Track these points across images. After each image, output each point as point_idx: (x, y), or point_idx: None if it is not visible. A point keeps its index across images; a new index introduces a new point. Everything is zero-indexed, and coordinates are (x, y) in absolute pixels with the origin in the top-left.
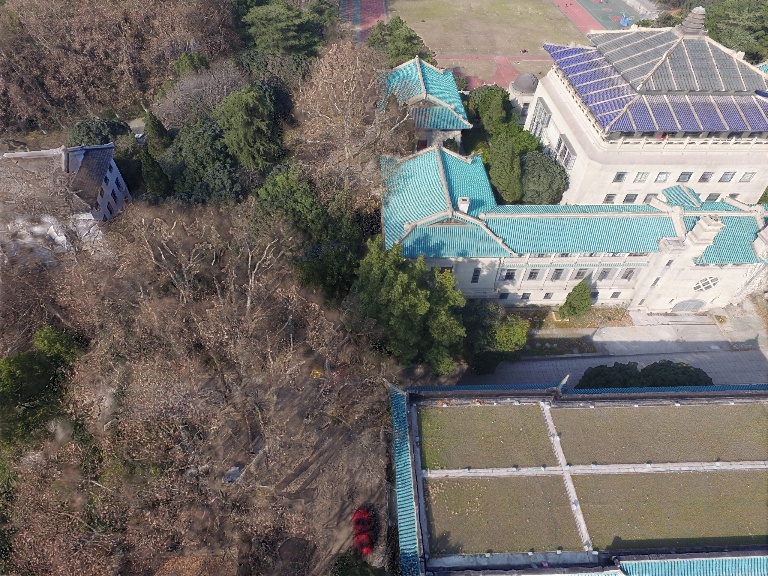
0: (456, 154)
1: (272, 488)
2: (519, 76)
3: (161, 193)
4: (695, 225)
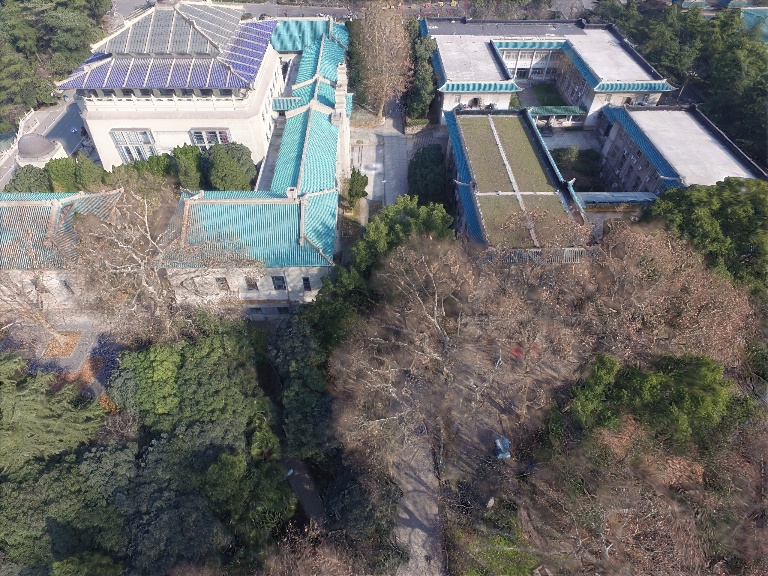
0: (197, 196)
1: (504, 416)
2: (22, 145)
3: (119, 568)
4: (335, 98)
